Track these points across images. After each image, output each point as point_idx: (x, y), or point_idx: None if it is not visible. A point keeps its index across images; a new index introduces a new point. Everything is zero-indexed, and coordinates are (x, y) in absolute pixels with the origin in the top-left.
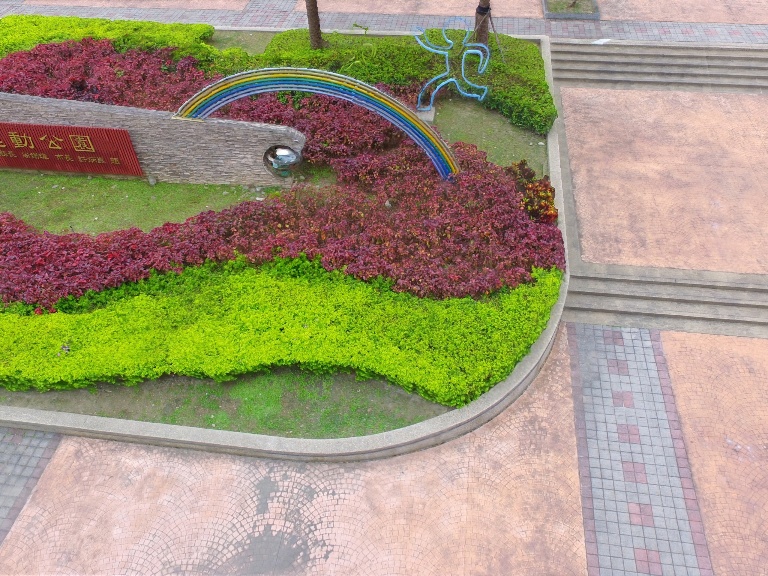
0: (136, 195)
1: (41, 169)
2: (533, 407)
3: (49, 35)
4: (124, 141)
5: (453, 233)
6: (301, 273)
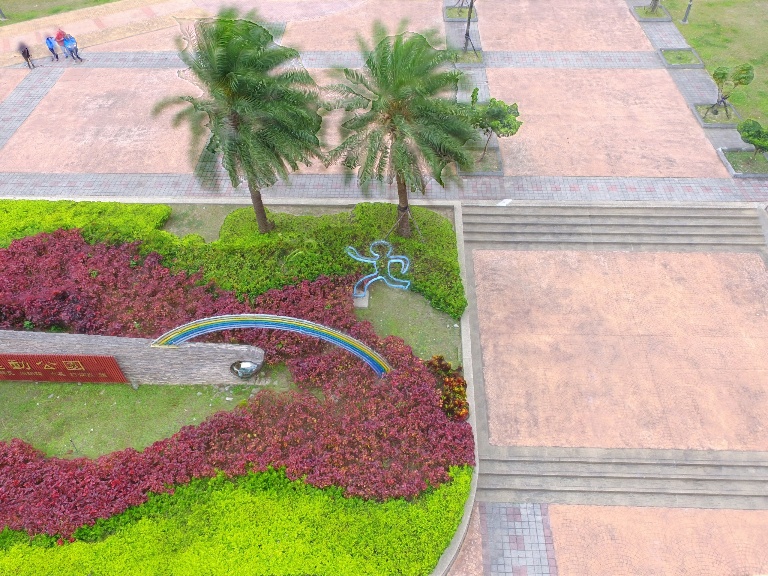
0: (123, 401)
1: (36, 380)
2: None
3: (21, 225)
4: (111, 363)
5: (388, 434)
6: (270, 485)
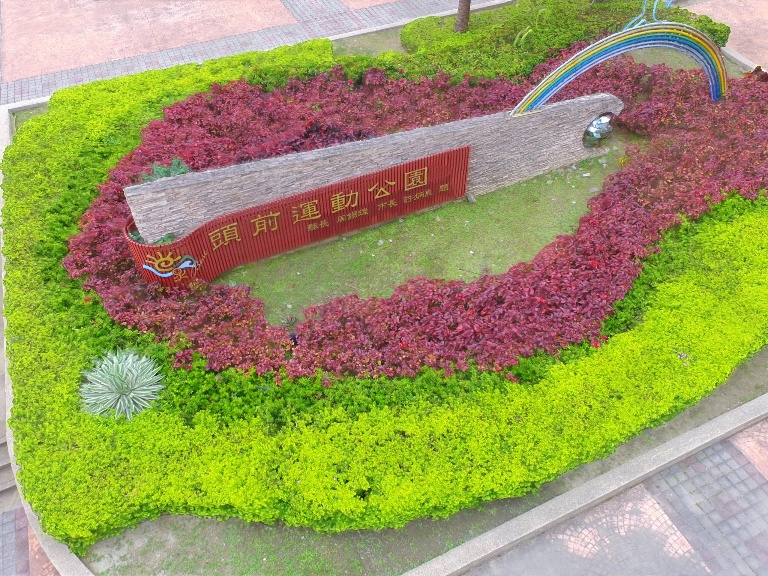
0: (474, 217)
1: (348, 231)
2: None
3: (154, 96)
4: (463, 160)
5: None
6: (740, 210)
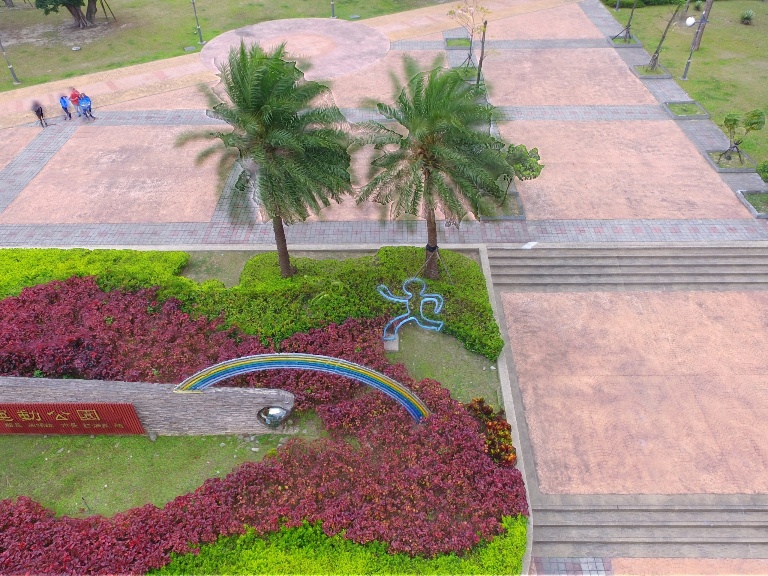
0: (140, 454)
1: (45, 433)
2: None
3: (33, 274)
4: (129, 412)
5: (431, 483)
6: (306, 542)
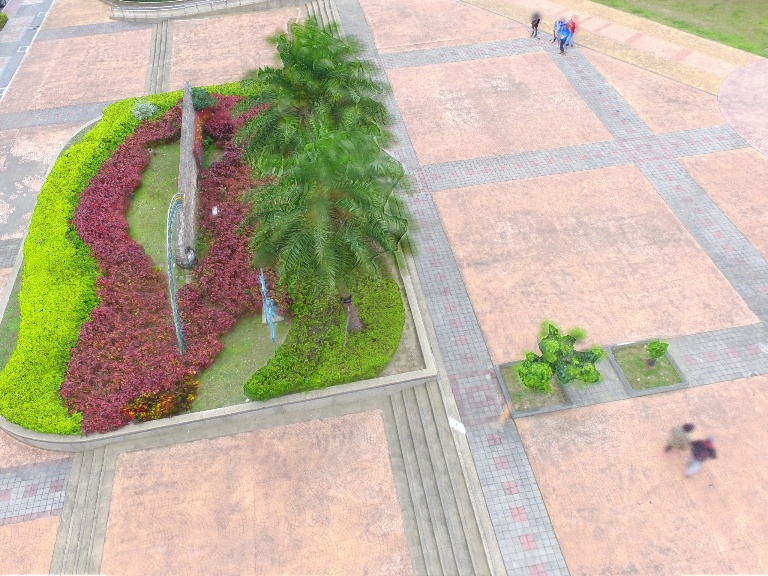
0: None
1: None
2: (6, 447)
3: None
4: None
5: None
6: None
